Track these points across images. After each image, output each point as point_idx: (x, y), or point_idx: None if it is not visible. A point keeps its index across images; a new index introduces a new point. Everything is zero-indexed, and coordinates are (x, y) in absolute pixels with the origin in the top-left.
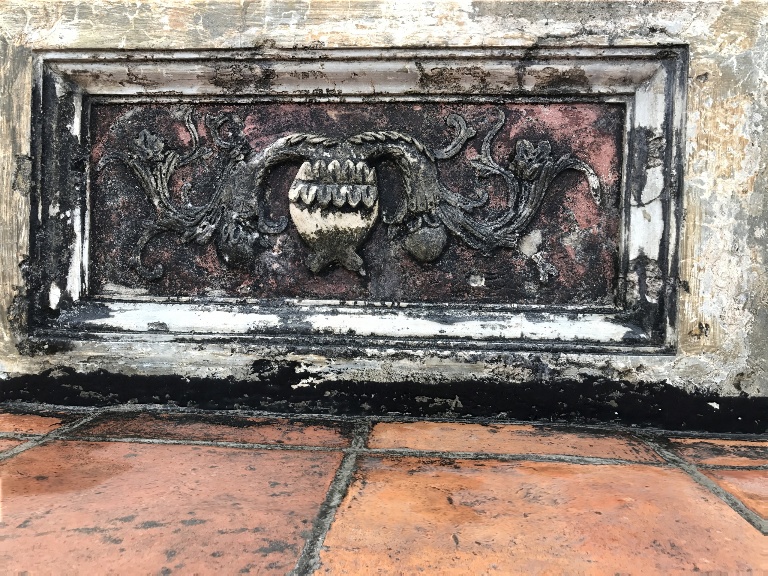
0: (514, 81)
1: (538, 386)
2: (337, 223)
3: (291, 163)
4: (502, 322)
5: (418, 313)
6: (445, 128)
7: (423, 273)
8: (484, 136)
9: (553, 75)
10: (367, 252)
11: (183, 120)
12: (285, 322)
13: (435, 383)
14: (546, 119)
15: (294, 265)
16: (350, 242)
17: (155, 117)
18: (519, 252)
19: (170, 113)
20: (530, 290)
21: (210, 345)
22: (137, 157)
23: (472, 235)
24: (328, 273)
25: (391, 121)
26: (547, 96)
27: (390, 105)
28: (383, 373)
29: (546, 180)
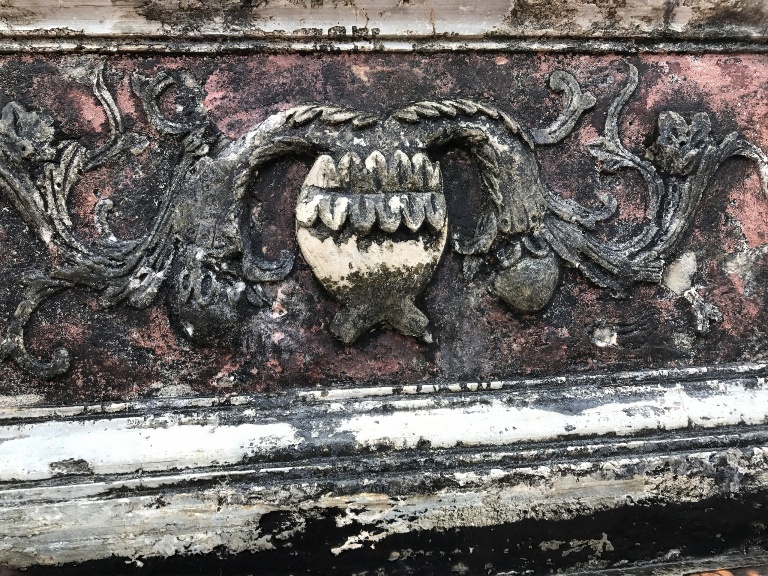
0: (658, 16)
1: (724, 503)
2: (386, 260)
3: (294, 157)
4: (653, 402)
5: (523, 398)
6: (547, 94)
7: (523, 331)
8: (607, 106)
9: (719, 6)
10: (431, 303)
11: (87, 83)
12: (307, 436)
13: (570, 517)
14: (698, 78)
15: (310, 332)
16: (407, 290)
17: (31, 78)
18: (665, 288)
19: (61, 70)
20: (682, 345)
21: (177, 496)
22: (2, 154)
23: (596, 266)
24: (368, 342)
25: (459, 83)
26: (701, 41)
27: (457, 56)
28: (486, 511)
29: (706, 175)
